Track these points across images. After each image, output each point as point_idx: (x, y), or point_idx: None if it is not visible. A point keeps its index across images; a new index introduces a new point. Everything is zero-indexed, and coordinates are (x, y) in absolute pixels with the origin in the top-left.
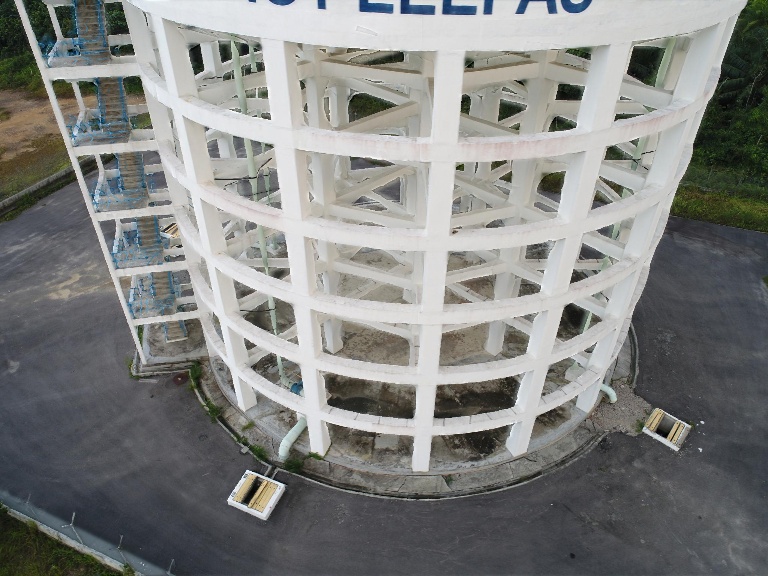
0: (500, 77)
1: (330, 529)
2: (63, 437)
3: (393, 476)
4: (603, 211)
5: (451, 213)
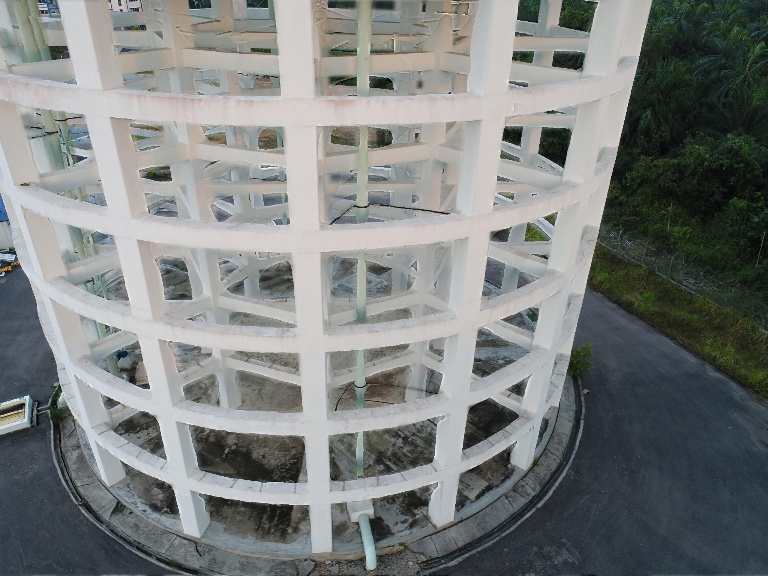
0: (250, 66)
1: (4, 476)
2: (5, 313)
3: (92, 472)
4: (165, 220)
5: (6, 157)
